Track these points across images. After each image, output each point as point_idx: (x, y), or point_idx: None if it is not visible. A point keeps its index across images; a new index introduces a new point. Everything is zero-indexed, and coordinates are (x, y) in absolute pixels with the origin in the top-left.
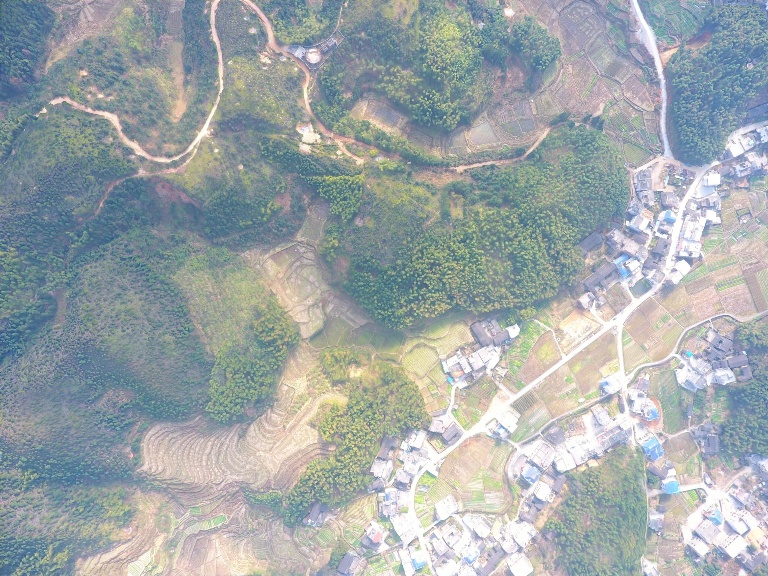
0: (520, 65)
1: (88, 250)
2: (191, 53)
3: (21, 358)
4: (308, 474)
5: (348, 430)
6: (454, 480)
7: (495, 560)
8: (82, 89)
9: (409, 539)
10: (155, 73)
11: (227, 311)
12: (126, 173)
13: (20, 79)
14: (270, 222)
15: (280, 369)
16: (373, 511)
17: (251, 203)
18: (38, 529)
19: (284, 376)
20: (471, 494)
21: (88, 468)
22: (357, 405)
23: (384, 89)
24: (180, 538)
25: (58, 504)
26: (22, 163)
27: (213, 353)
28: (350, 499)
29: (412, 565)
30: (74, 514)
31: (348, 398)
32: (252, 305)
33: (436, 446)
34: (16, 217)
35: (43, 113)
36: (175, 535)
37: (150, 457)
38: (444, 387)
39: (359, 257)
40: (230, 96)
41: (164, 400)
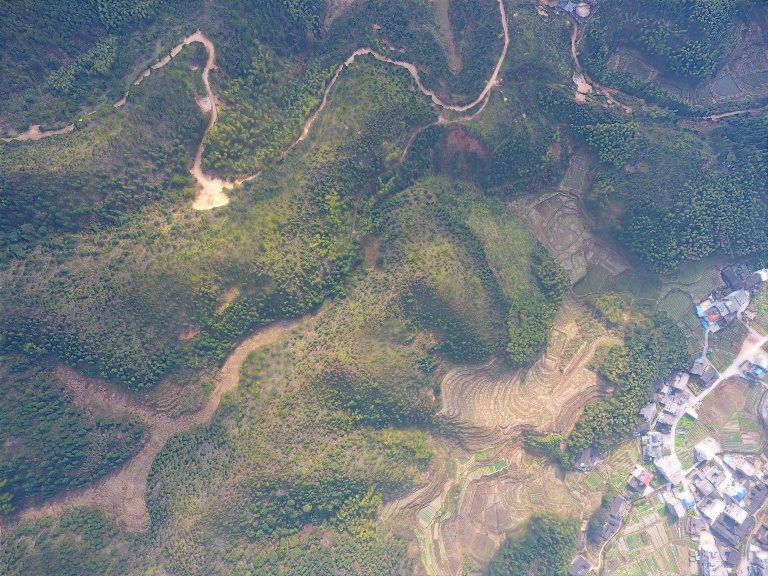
0: (758, 20)
1: (386, 197)
2: (467, 9)
3: (347, 299)
4: (592, 415)
5: (631, 370)
6: (711, 422)
7: (761, 498)
8: (379, 41)
9: (678, 480)
10: (430, 29)
11: (511, 257)
12: (430, 120)
13: (312, 34)
14: (542, 171)
15: (553, 315)
16: (637, 454)
17: (533, 151)
18: (364, 469)
19: (555, 322)
20: (728, 435)
21: (399, 410)
22: (636, 346)
23: (643, 42)
24: (463, 484)
25: (374, 446)
26: (347, 108)
27: (508, 296)
28: (616, 443)
29: (683, 505)
30: (389, 456)
31: (623, 340)
32: (528, 252)
33: (693, 389)
34: (339, 162)
35: (352, 63)
36: (460, 481)
37: (447, 400)
38: (698, 331)
39: (636, 201)
40: (519, 46)
41: (476, 340)
